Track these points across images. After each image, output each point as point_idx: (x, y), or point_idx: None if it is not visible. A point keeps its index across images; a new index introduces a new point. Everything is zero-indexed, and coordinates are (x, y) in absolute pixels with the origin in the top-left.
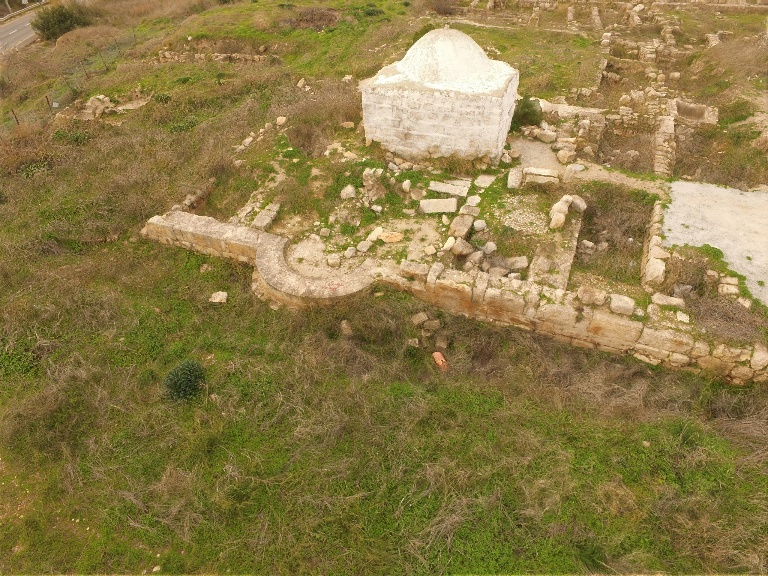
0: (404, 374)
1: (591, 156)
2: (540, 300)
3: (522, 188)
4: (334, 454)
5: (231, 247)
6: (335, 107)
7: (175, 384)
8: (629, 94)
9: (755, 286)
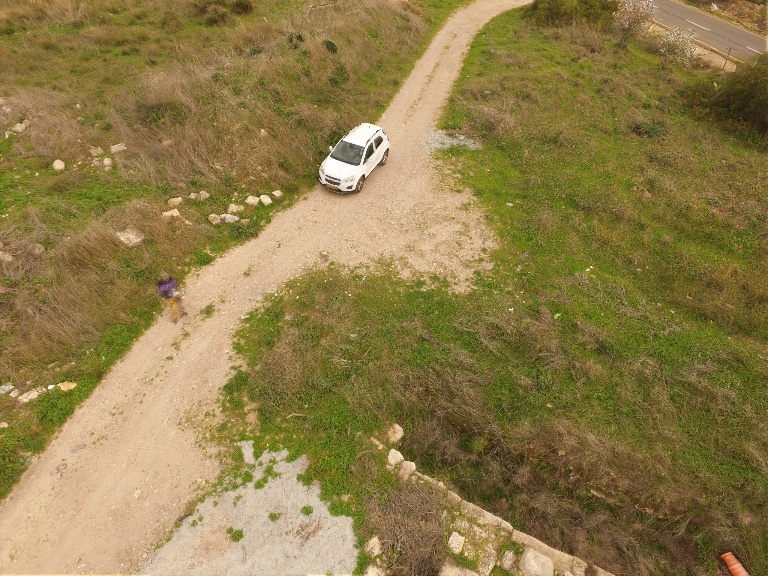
0: None
1: None
2: None
3: None
4: None
5: None
6: None
7: None
8: None
9: (340, 574)
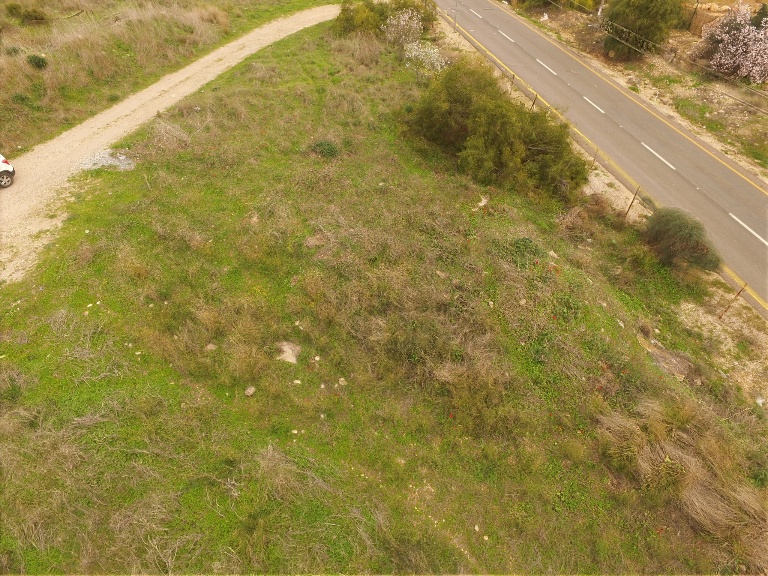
0: None
1: None
2: None
3: None
4: (141, 493)
5: None
6: None
7: None
8: None
9: None
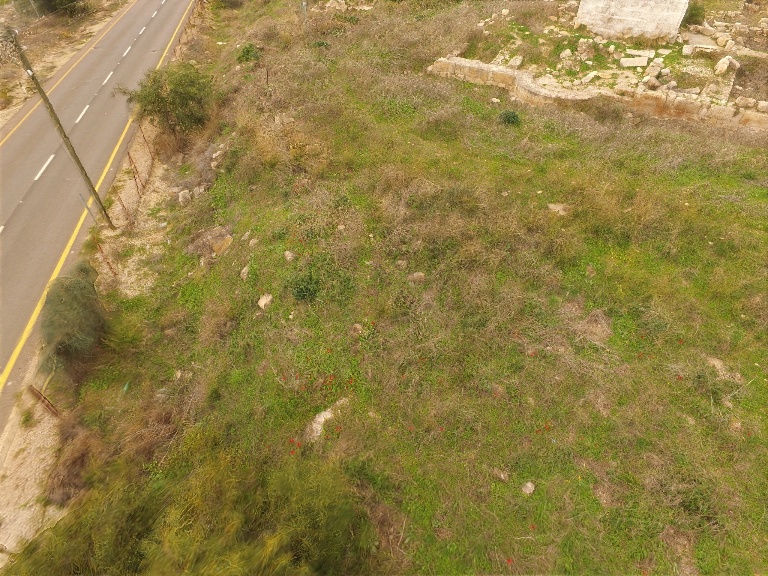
0: (633, 125)
1: (741, 44)
2: (711, 104)
3: (693, 55)
4: None
5: (496, 76)
6: (546, 4)
7: (506, 117)
8: (767, 18)
9: None
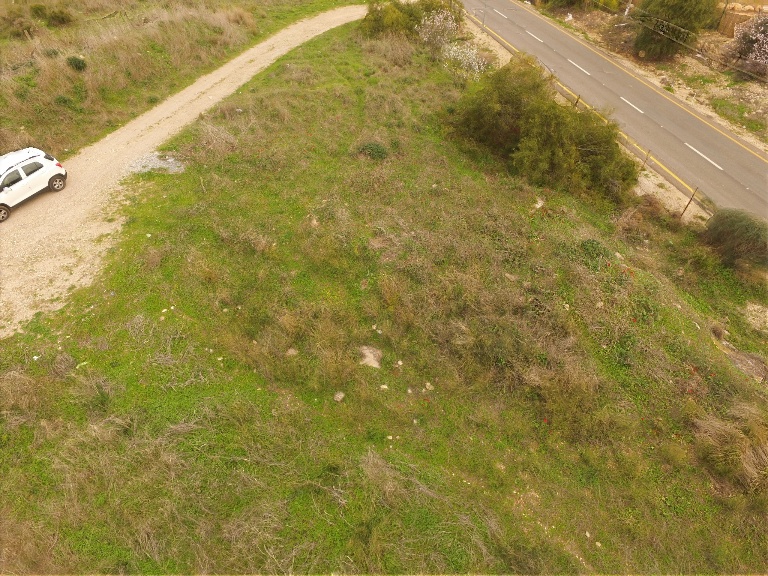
0: None
1: None
2: None
3: None
4: (247, 502)
5: None
6: None
7: None
8: None
9: None
